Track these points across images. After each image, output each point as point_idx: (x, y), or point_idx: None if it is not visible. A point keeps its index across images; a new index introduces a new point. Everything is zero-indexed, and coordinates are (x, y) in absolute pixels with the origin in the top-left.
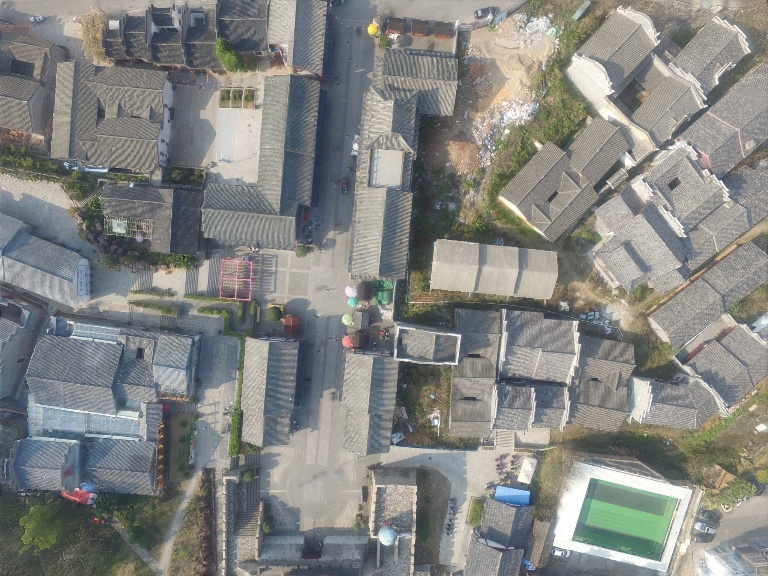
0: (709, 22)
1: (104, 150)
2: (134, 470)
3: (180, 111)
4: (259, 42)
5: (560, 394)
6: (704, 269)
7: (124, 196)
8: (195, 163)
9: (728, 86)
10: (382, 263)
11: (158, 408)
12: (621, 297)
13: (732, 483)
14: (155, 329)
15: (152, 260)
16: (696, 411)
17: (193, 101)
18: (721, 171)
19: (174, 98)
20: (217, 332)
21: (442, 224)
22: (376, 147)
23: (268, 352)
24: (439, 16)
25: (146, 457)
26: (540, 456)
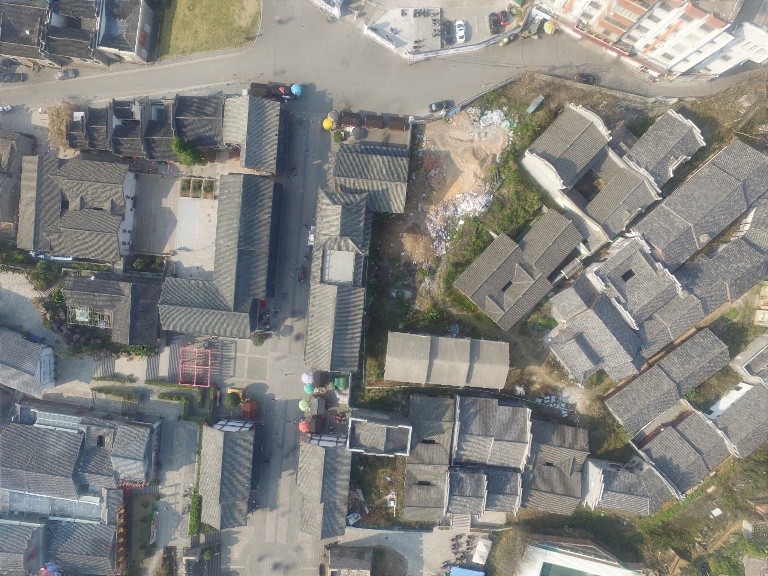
0: (665, 114)
1: (67, 242)
2: (95, 554)
3: (142, 199)
4: (215, 138)
5: (514, 480)
6: (662, 352)
7: (85, 289)
8: (157, 250)
9: (687, 173)
10: (334, 358)
11: (118, 493)
12: (577, 381)
13: (685, 569)
14: (117, 414)
15: (114, 348)
16: (649, 499)
17: (155, 189)
18: (675, 263)
19: (137, 187)
20: (177, 417)
21: (398, 311)
22: (326, 248)
23: (223, 442)
24: (394, 109)
25: (106, 541)
26: (496, 536)
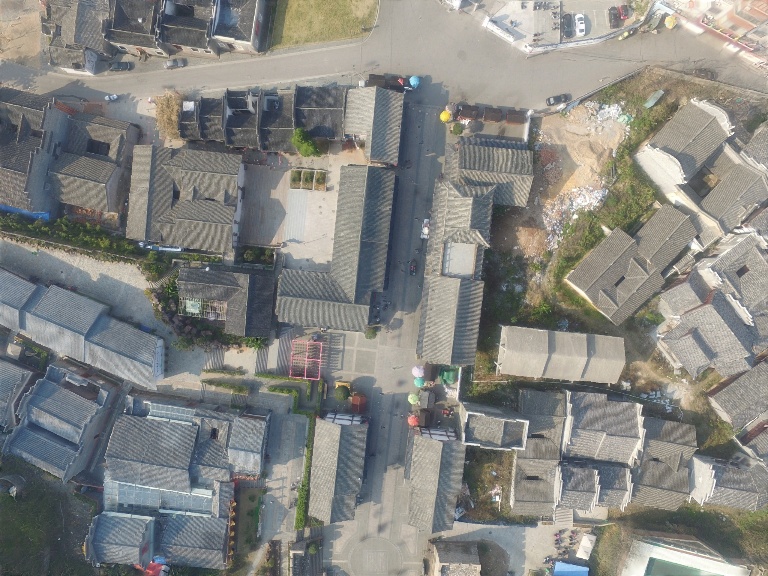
0: None
1: (179, 232)
2: (208, 548)
3: (251, 190)
4: (334, 129)
5: (622, 475)
6: None
7: (200, 280)
8: (265, 241)
9: None
10: (454, 351)
11: (230, 486)
12: (682, 377)
13: None
14: (226, 407)
15: (224, 340)
16: (758, 495)
17: (264, 181)
18: None
19: (245, 178)
20: (286, 410)
21: (508, 305)
22: (452, 241)
23: (340, 435)
24: (511, 102)
25: (219, 534)
26: (598, 531)
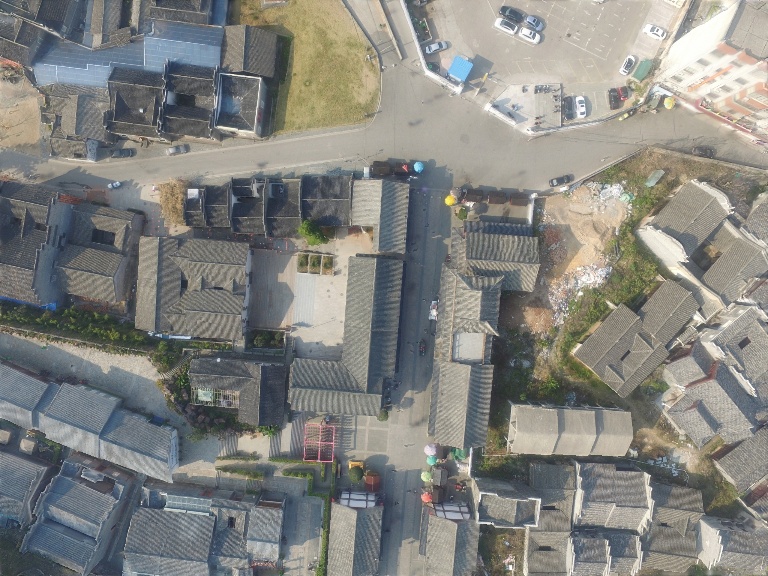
0: None
1: (189, 323)
2: None
3: (258, 275)
4: (340, 218)
5: (632, 542)
6: None
7: (212, 371)
8: (274, 325)
9: None
10: (466, 436)
11: (249, 572)
12: (688, 442)
13: None
14: (242, 492)
15: (238, 427)
16: (763, 557)
17: (271, 265)
18: None
19: (252, 262)
20: (301, 492)
21: (516, 381)
22: (462, 331)
23: (356, 521)
24: (514, 184)
25: None
26: None
